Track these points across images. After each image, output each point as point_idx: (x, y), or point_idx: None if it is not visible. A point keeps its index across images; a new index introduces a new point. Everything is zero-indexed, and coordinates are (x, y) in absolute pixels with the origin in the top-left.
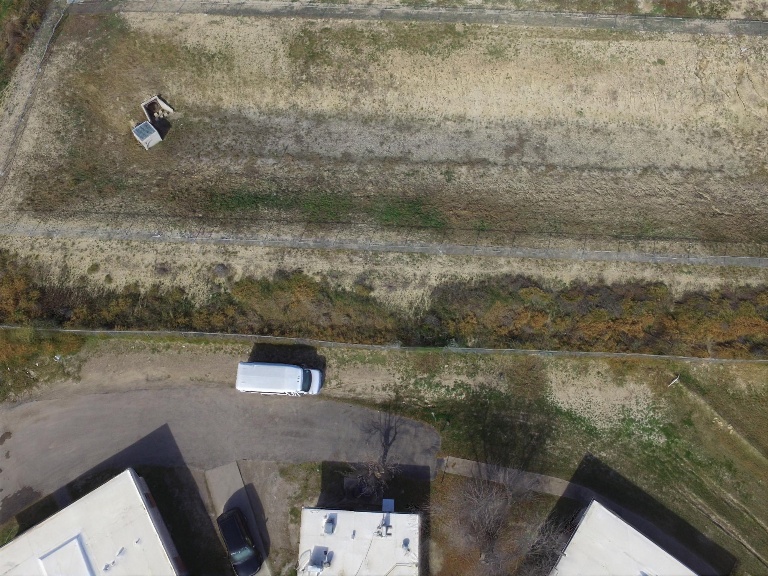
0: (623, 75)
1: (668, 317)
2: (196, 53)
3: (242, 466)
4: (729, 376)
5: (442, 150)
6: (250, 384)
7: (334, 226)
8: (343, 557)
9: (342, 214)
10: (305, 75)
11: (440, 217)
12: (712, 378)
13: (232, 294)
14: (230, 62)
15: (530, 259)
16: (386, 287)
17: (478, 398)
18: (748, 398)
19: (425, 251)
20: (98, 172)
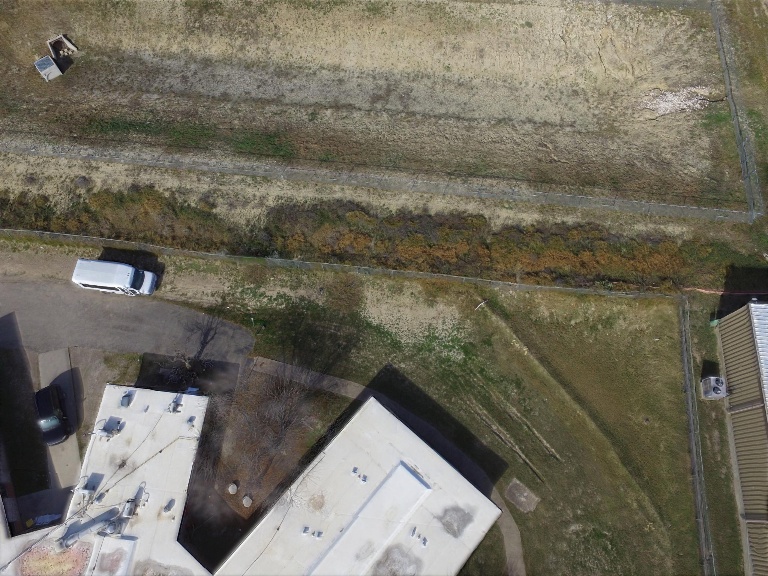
0: (491, 35)
1: (482, 246)
2: None
3: (72, 352)
4: (534, 304)
5: (313, 95)
6: (84, 277)
7: (191, 150)
8: (133, 427)
9: (202, 141)
10: (198, 23)
11: (290, 148)
12: (518, 305)
13: (89, 203)
14: (132, 8)
15: (363, 188)
16: (227, 205)
17: (296, 308)
18: (549, 325)
19: (268, 175)
20: None
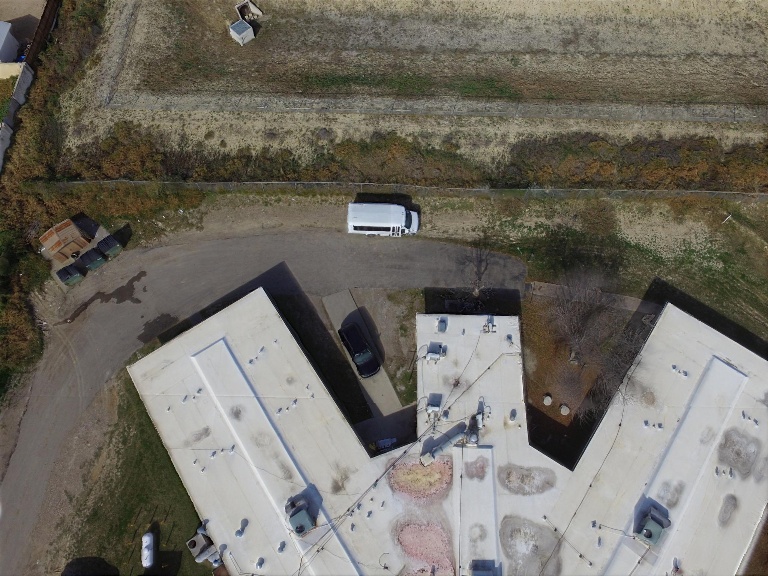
0: None
1: (720, 164)
2: None
3: (354, 293)
4: None
5: (506, 42)
6: (361, 219)
7: (420, 97)
8: (456, 349)
9: (426, 89)
10: None
11: (513, 90)
12: (760, 215)
13: (335, 153)
14: None
15: (596, 120)
16: (471, 145)
17: (557, 236)
18: None
19: (503, 115)
20: (202, 62)
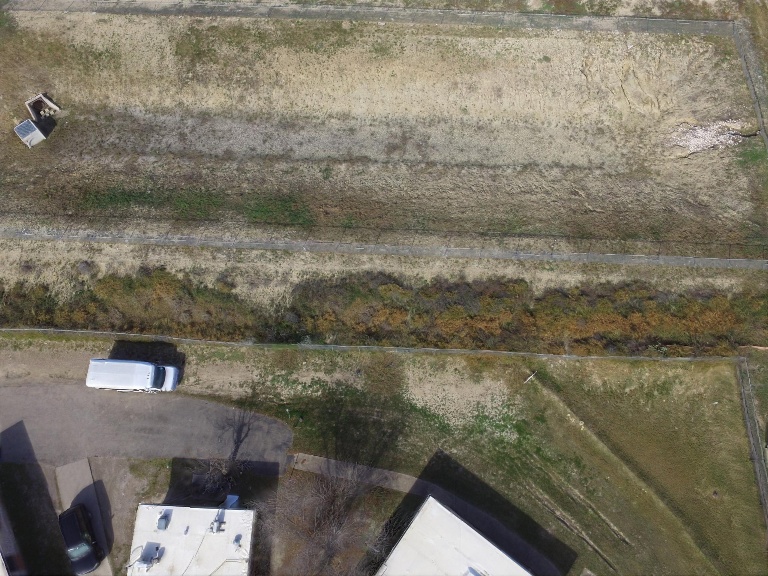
0: (508, 72)
1: (526, 314)
2: (83, 51)
3: (93, 463)
4: (586, 373)
5: (324, 148)
6: (99, 381)
7: (201, 223)
8: (174, 553)
9: (212, 212)
10: (191, 73)
11: (309, 214)
12: (568, 375)
13: (94, 291)
14: (117, 60)
15: (393, 256)
16: (248, 284)
17: (334, 395)
18: (603, 395)
19: (289, 248)
20: None
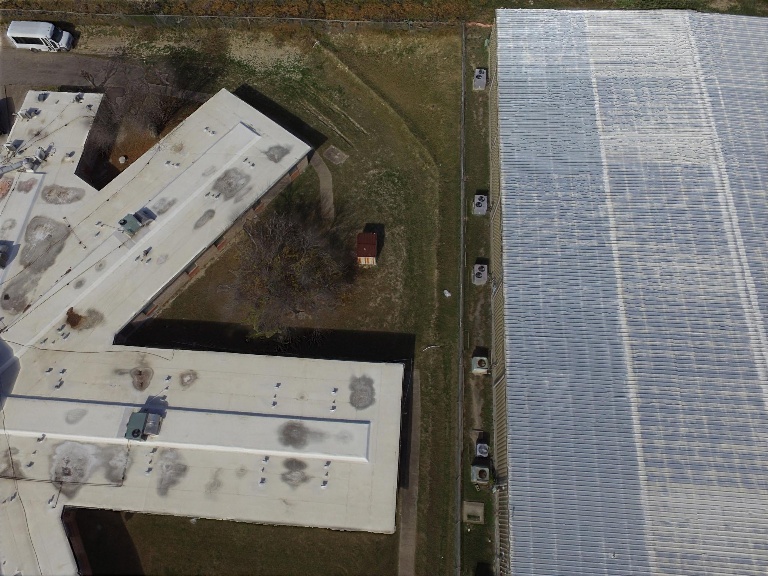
0: None
1: (318, 4)
2: None
3: (8, 88)
4: (357, 42)
5: None
6: (15, 31)
7: None
8: (47, 113)
9: None
10: None
11: None
12: (344, 43)
13: None
14: None
15: None
16: None
17: (178, 54)
18: (367, 55)
19: None
20: None
